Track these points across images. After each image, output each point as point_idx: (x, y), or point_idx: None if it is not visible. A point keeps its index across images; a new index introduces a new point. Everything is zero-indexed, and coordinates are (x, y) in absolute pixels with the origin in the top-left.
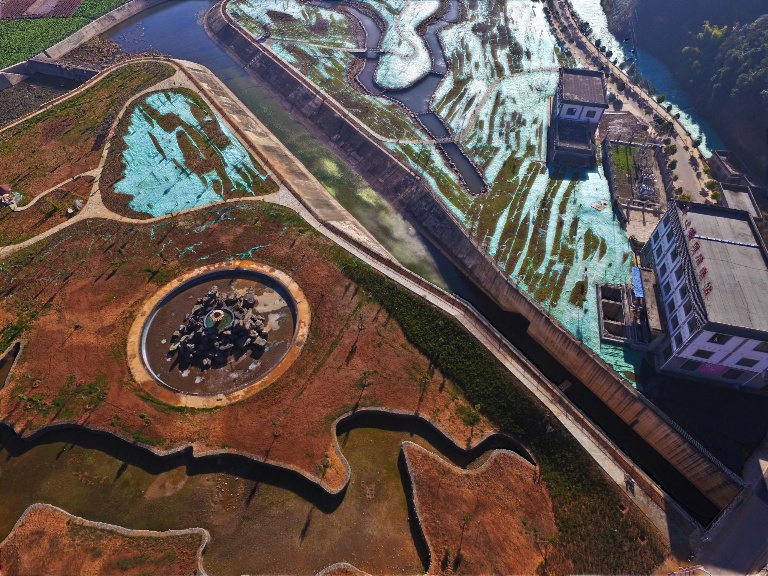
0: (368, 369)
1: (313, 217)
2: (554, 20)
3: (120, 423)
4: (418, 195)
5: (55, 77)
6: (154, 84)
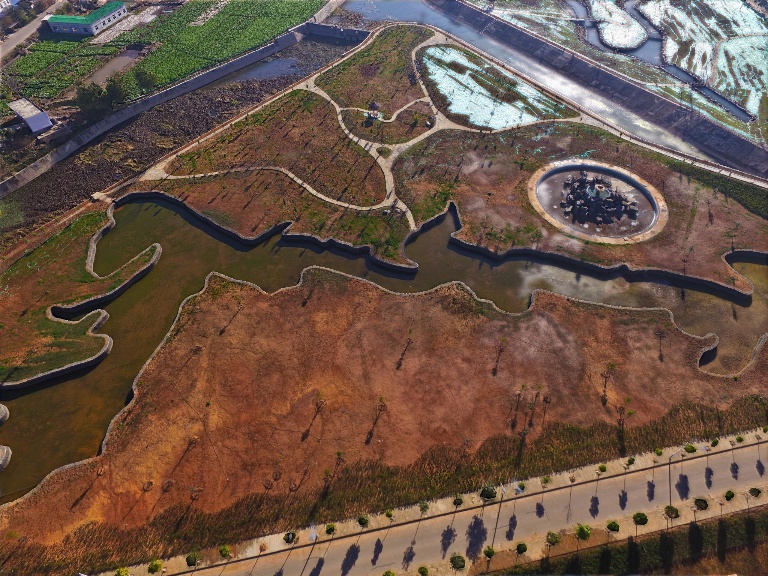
0: (729, 227)
1: None
2: None
3: (564, 249)
4: (694, 122)
5: (327, 37)
6: (424, 41)
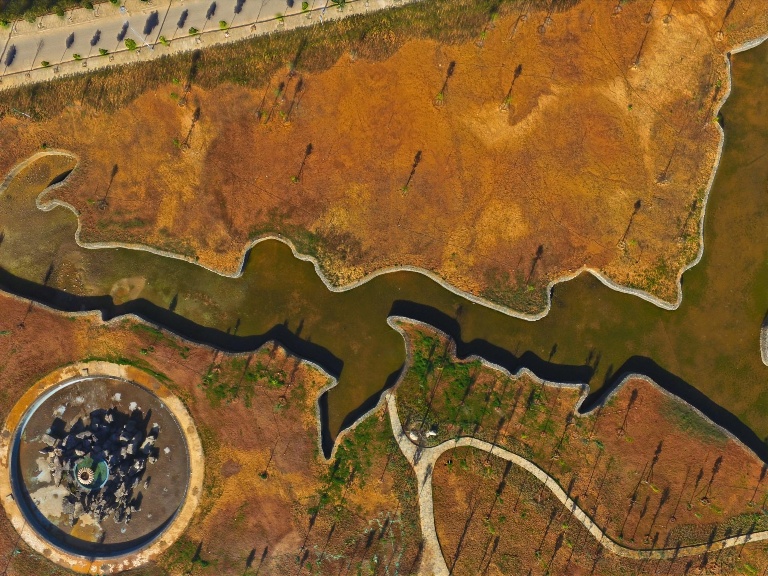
0: None
1: None
2: None
3: (180, 350)
4: None
5: None
6: None
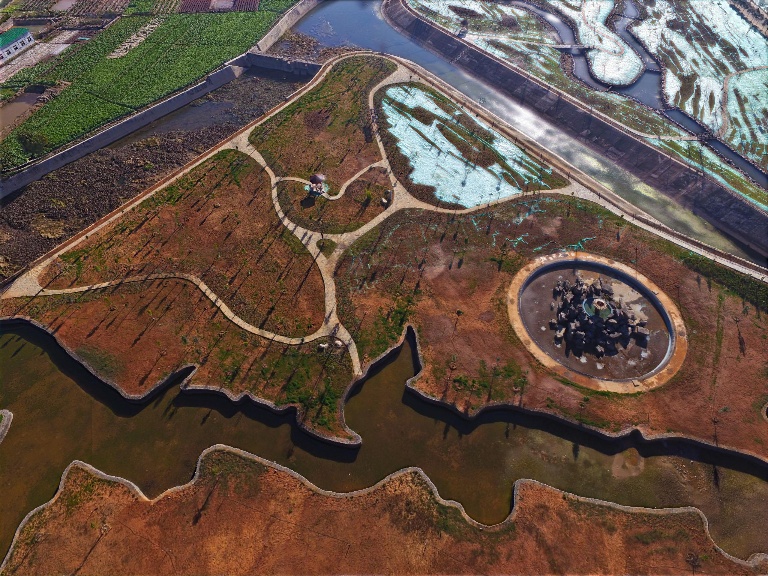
0: (767, 360)
1: (621, 211)
2: (752, 17)
3: (556, 405)
4: (707, 191)
5: (272, 70)
6: (385, 78)
